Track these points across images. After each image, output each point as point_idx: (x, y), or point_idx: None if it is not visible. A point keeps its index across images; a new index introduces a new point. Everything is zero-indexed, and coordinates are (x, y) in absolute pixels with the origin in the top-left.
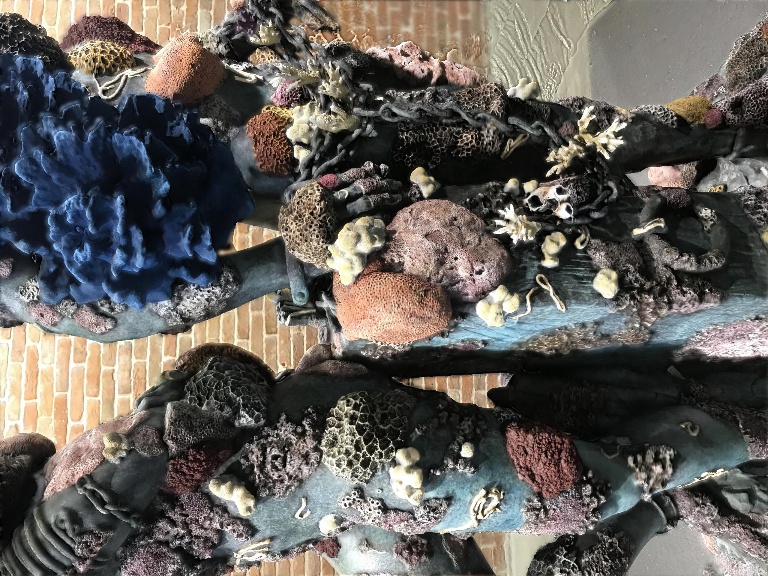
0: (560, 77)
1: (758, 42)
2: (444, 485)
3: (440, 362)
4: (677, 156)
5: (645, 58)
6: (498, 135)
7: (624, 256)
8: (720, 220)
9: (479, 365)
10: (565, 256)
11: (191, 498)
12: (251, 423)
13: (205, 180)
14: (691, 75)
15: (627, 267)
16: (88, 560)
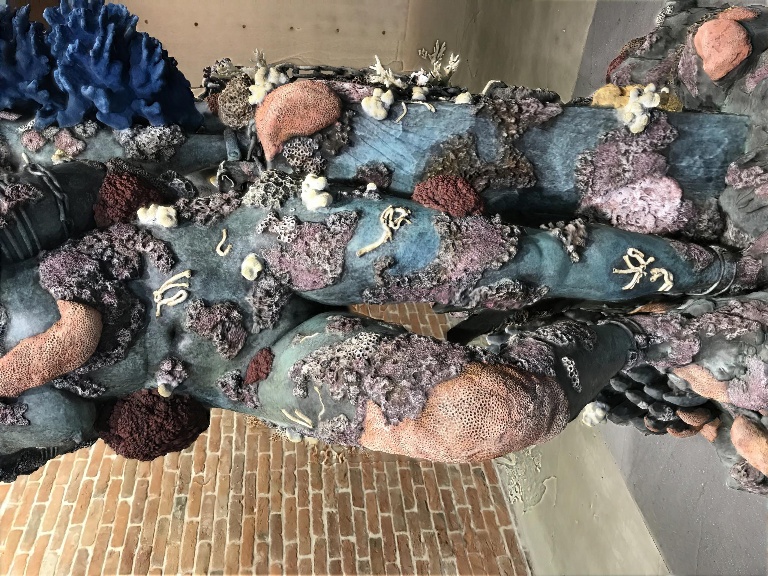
0: None
1: None
2: (352, 204)
3: None
4: None
5: None
6: None
7: None
8: None
9: None
10: (432, 100)
11: (120, 226)
12: (182, 186)
13: (166, 76)
14: None
15: None
16: (15, 201)
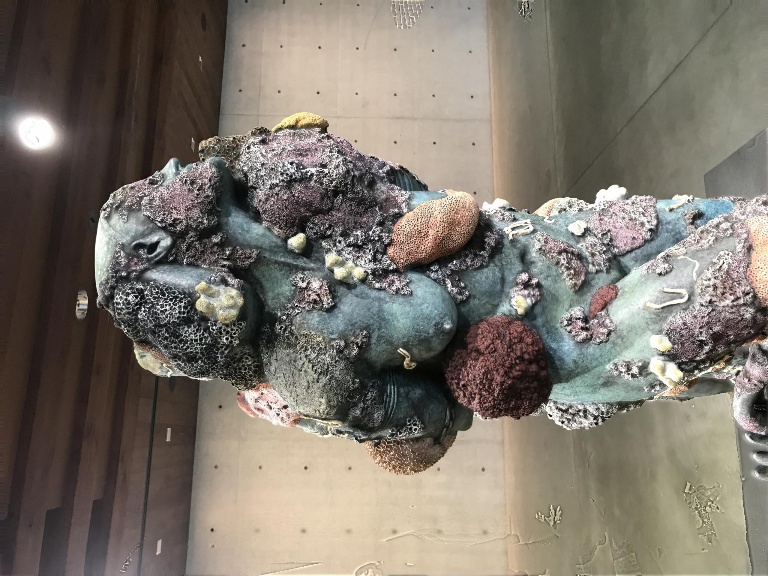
0: None
1: None
2: None
3: None
4: None
5: None
6: None
7: None
8: None
9: None
10: None
11: None
12: None
13: None
14: None
15: None
16: None
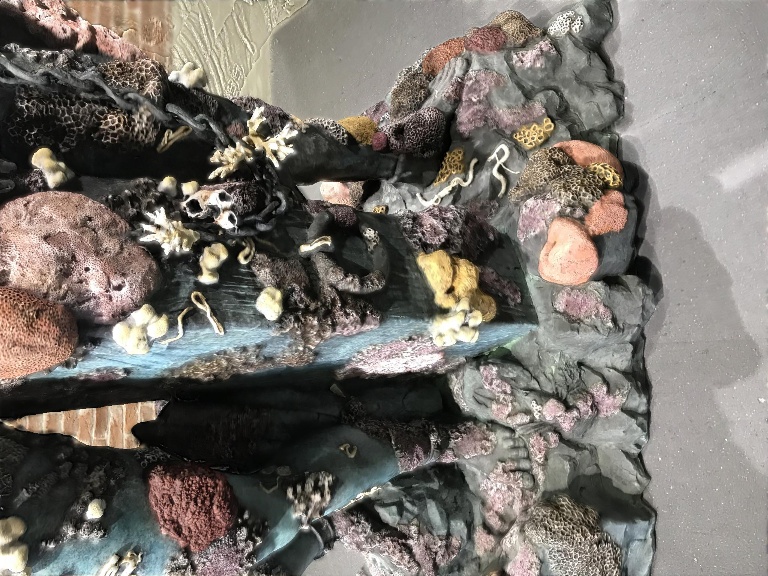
0: (243, 80)
1: (418, 76)
2: (61, 559)
3: (69, 396)
4: (346, 173)
5: (322, 75)
6: (153, 123)
7: (290, 274)
8: (382, 242)
9: (123, 395)
10: (226, 271)
11: None
12: None
13: None
14: (362, 99)
15: (292, 286)
16: None
